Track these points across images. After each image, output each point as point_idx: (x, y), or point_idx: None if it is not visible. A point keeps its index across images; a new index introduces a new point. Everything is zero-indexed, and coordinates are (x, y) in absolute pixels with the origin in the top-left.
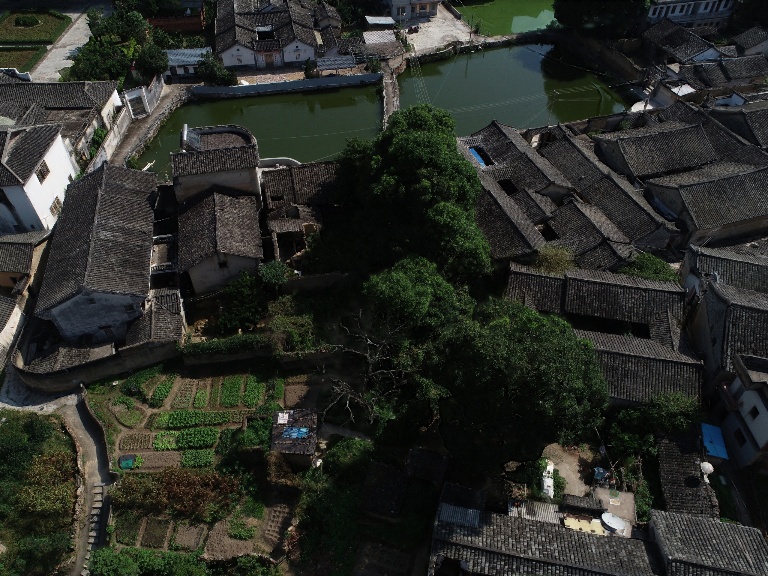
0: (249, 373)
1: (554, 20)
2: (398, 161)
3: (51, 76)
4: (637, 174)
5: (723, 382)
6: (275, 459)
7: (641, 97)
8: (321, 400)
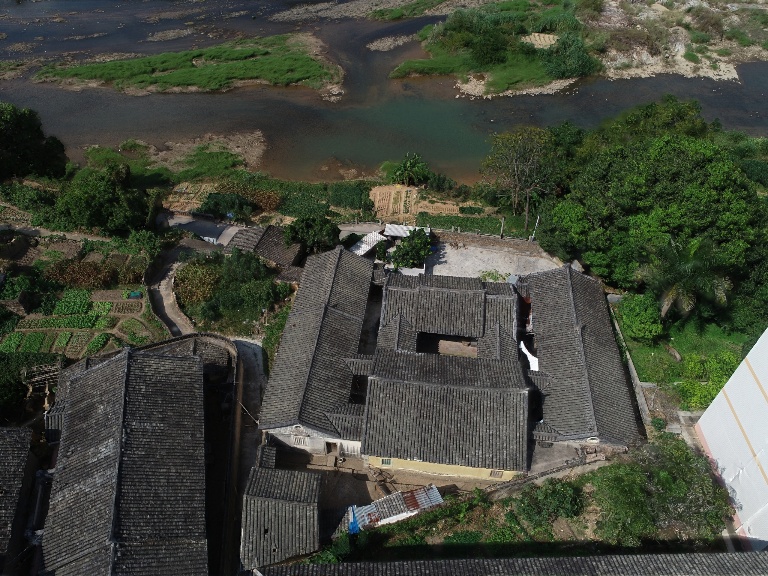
0: None
1: None
2: None
3: None
4: None
5: None
6: (2, 264)
7: None
8: None
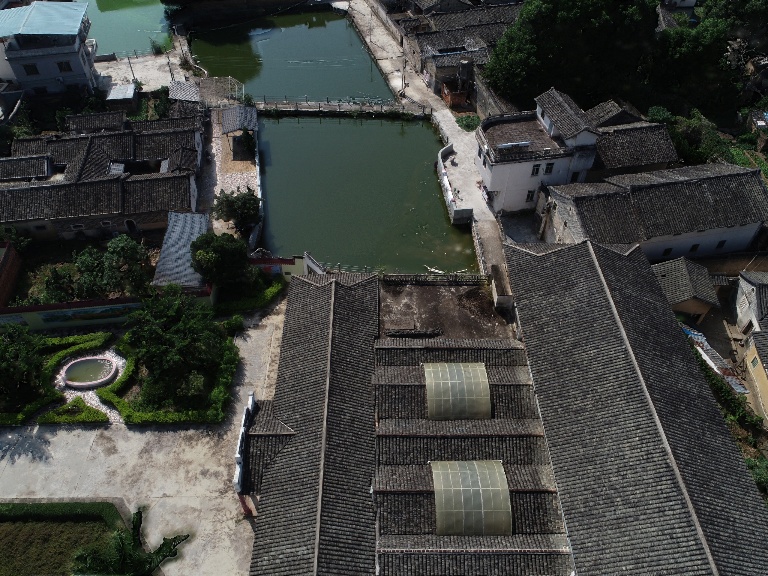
0: None
1: (164, 11)
2: (617, 1)
3: (132, 454)
4: (472, 4)
5: (664, 4)
6: None
7: (325, 3)
8: (724, 124)
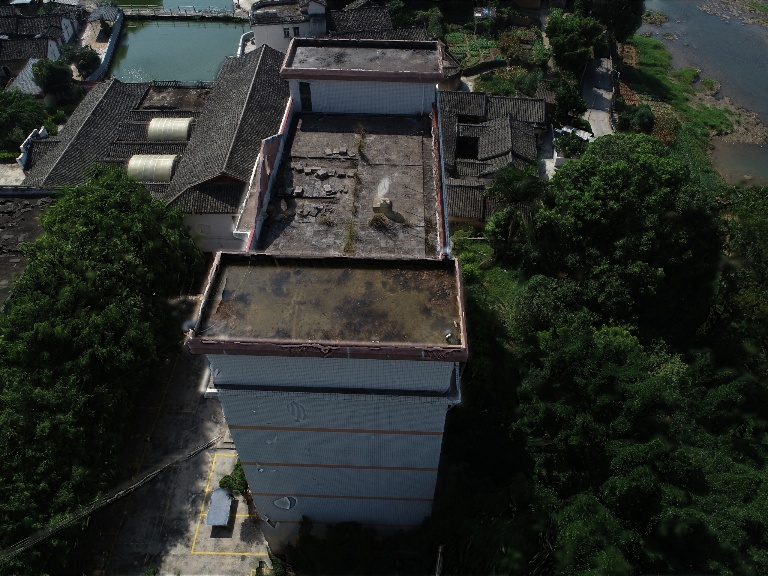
0: (444, 36)
1: None
2: None
3: None
4: None
5: None
6: None
7: None
8: (459, 19)
